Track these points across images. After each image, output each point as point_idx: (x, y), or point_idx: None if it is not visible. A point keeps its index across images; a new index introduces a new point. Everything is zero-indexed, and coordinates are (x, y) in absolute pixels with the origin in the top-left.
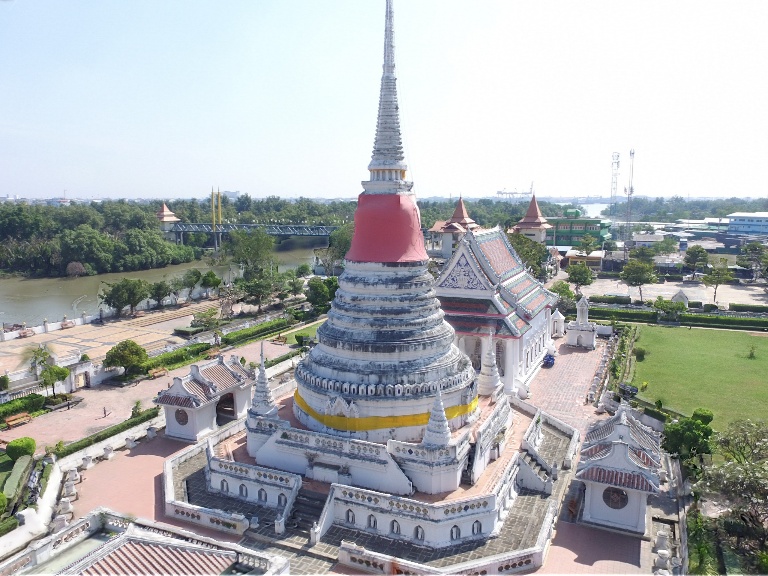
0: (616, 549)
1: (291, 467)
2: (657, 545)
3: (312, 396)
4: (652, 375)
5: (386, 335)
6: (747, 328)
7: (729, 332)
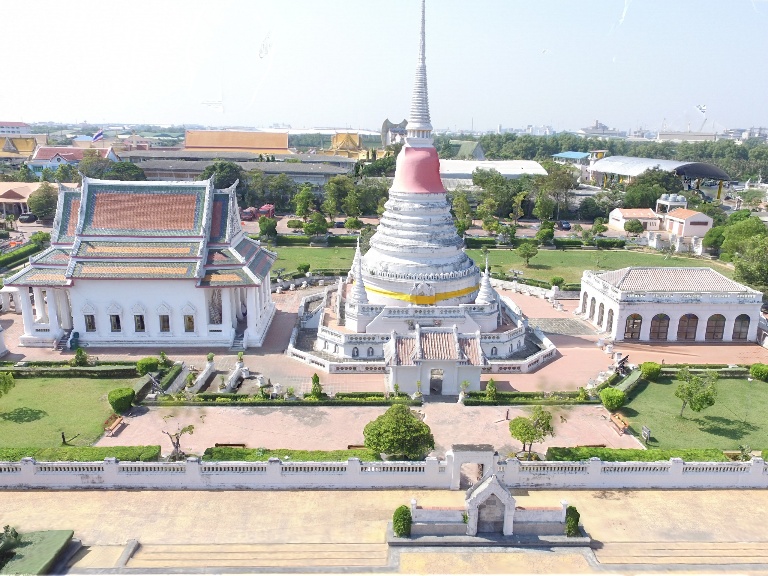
0: None
1: None
2: None
3: None
4: None
5: None
6: None
7: None
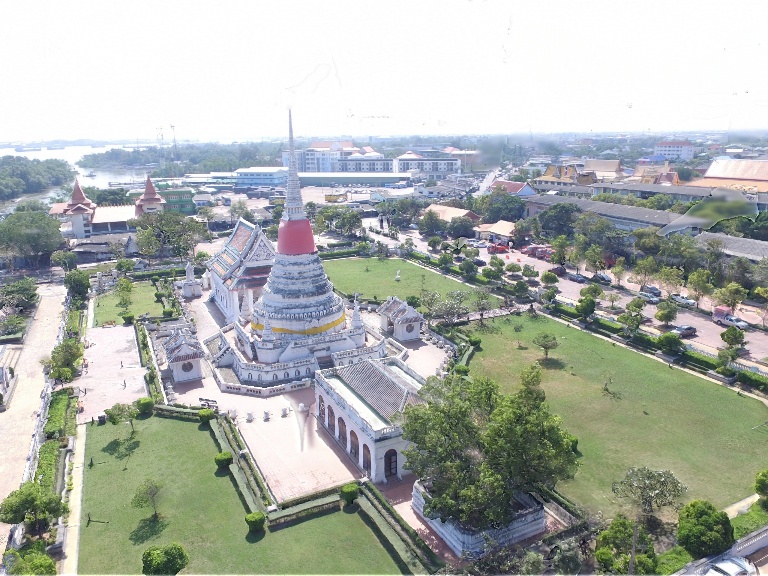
0: (419, 344)
1: (300, 358)
2: (427, 339)
3: (293, 324)
4: (345, 288)
5: (320, 287)
6: (348, 256)
7: (342, 260)
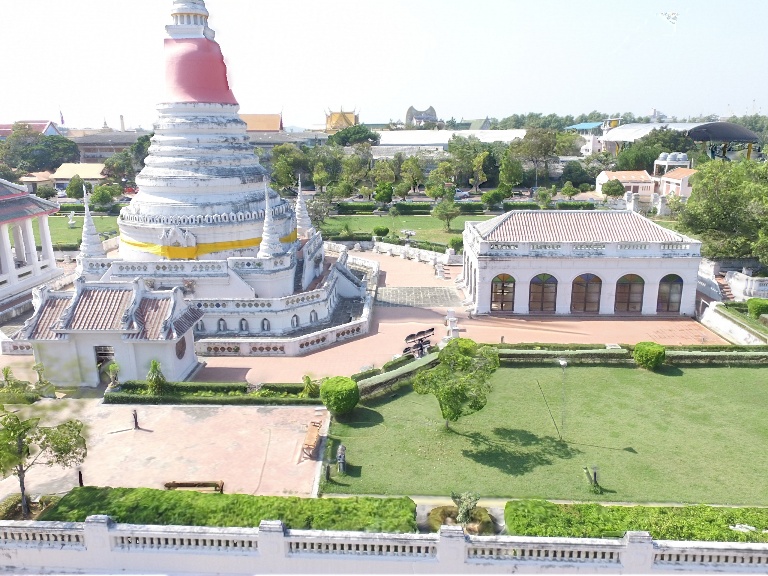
0: None
1: None
2: None
3: None
4: None
5: None
6: None
7: None
